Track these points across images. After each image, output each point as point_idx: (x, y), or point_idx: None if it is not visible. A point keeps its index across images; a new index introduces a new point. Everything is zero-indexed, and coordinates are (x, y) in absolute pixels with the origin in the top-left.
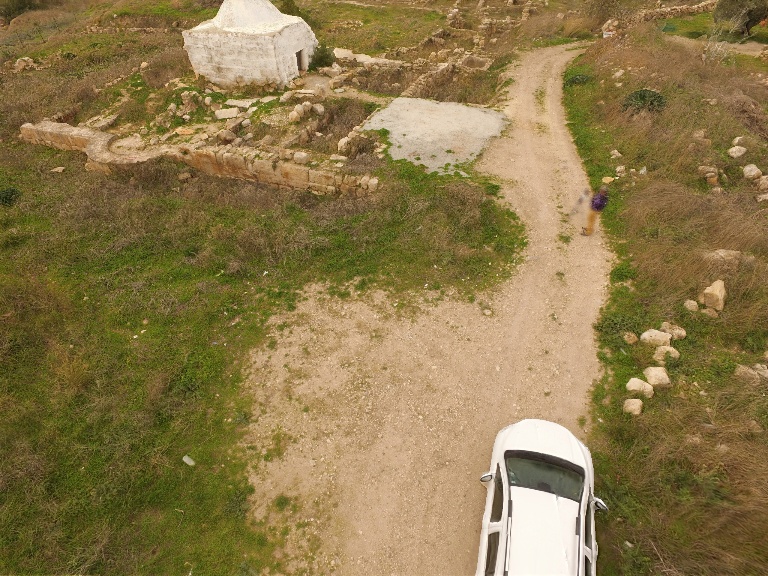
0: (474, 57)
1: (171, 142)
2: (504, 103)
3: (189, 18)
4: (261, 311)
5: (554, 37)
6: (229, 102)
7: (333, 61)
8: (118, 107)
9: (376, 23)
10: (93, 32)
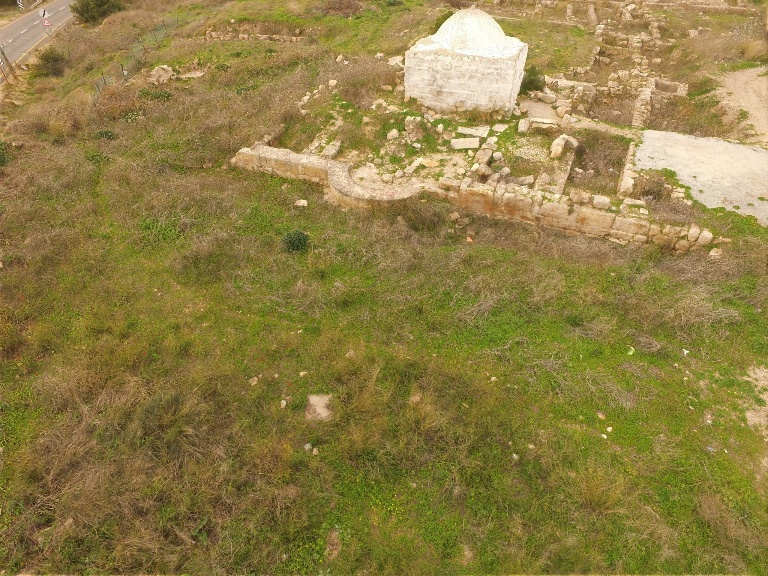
0: (659, 80)
1: (420, 175)
2: (761, 139)
3: (313, 26)
4: (728, 405)
5: (737, 60)
6: (461, 130)
7: (543, 85)
8: (336, 132)
9: (522, 38)
10: (213, 38)
